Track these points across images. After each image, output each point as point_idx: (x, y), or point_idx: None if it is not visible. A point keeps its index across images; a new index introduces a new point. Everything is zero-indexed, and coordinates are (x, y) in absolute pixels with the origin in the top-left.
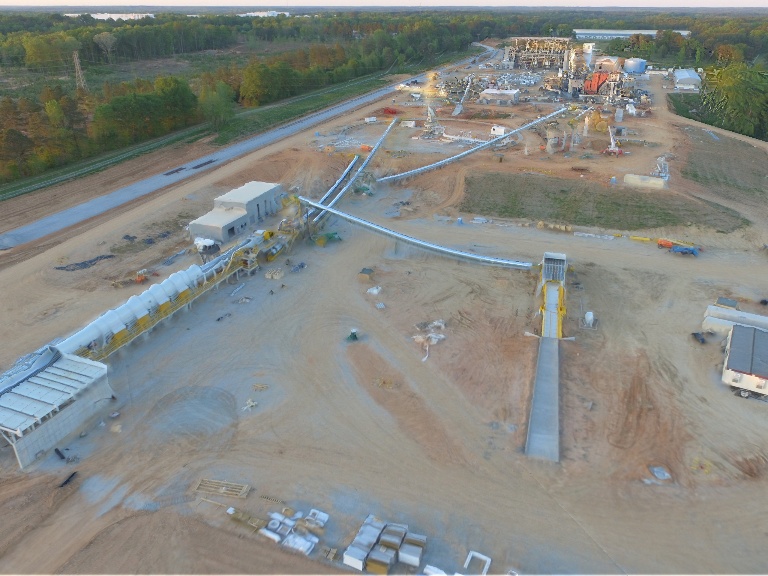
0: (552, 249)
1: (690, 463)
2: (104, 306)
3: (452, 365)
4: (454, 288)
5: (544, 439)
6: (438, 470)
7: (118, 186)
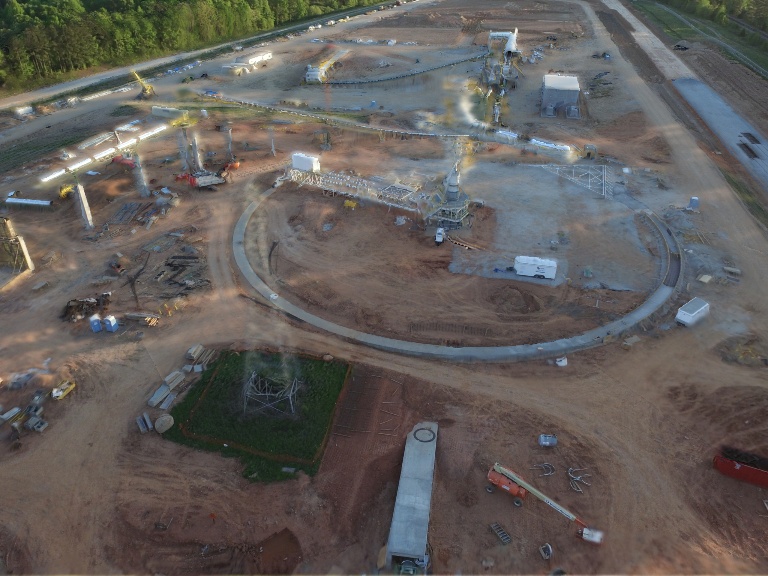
0: (306, 95)
1: (303, 52)
2: (549, 67)
3: (374, 60)
4: (375, 77)
5: (345, 51)
6: (377, 49)
7: (754, 119)
